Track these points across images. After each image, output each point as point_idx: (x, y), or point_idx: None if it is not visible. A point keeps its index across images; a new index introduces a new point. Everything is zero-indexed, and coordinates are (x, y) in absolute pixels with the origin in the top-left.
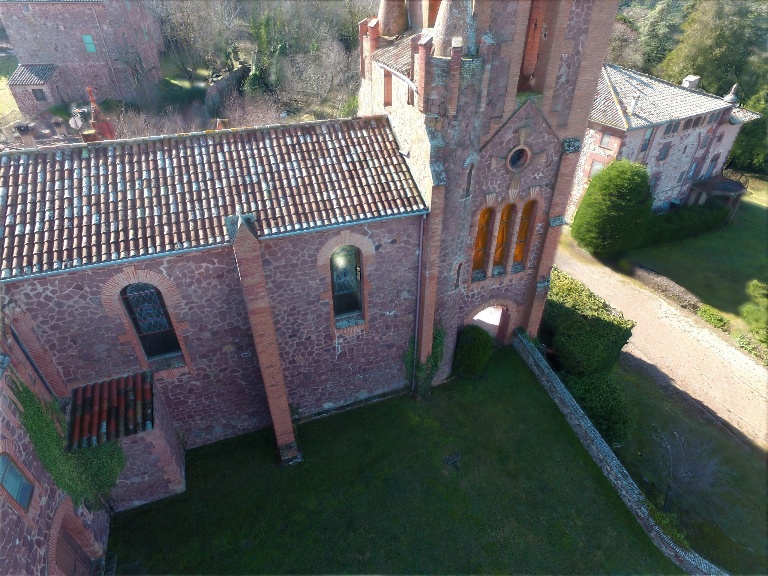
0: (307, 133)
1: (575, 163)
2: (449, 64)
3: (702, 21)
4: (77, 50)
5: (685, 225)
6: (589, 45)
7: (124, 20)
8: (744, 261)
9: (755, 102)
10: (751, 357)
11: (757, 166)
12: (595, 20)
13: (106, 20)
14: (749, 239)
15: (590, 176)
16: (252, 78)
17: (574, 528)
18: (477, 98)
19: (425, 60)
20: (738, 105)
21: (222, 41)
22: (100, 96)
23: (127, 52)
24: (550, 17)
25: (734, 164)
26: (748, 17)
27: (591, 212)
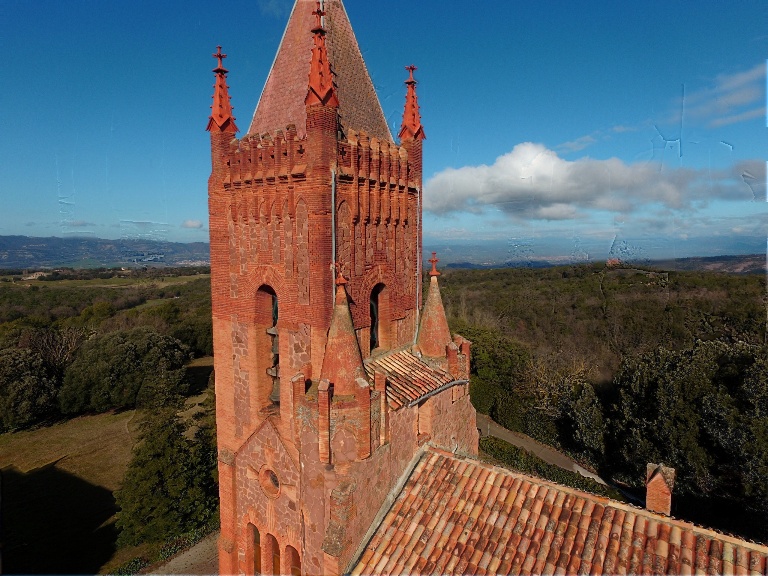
0: None
1: None
2: None
3: None
4: None
5: None
6: None
7: None
8: None
9: None
10: (180, 553)
11: None
12: None
13: None
14: None
15: None
16: None
17: None
18: None
19: None
20: None
21: None
22: None
23: None
24: None
25: None
26: None
27: None
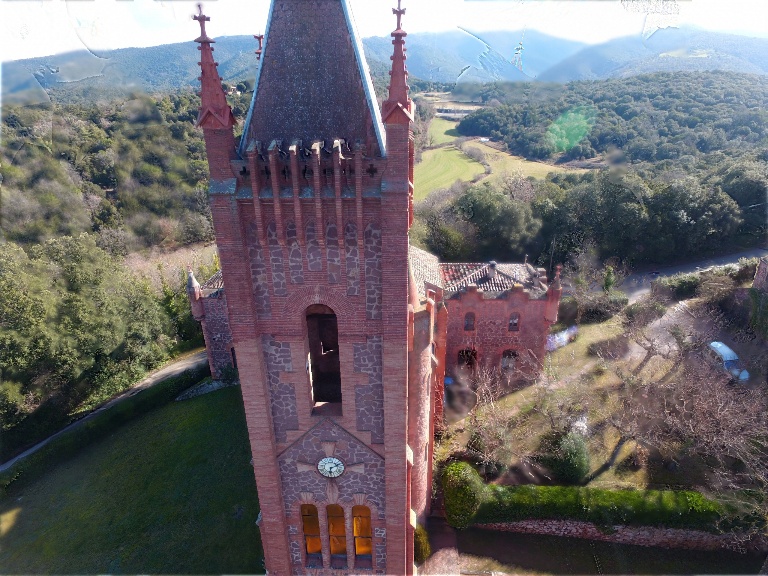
0: None
1: None
2: None
3: None
4: None
5: None
6: None
7: None
8: None
9: None
10: None
11: None
12: None
13: None
14: None
15: None
16: None
17: (151, 574)
18: None
19: None
20: None
21: None
22: None
23: None
24: None
25: None
26: None
27: None
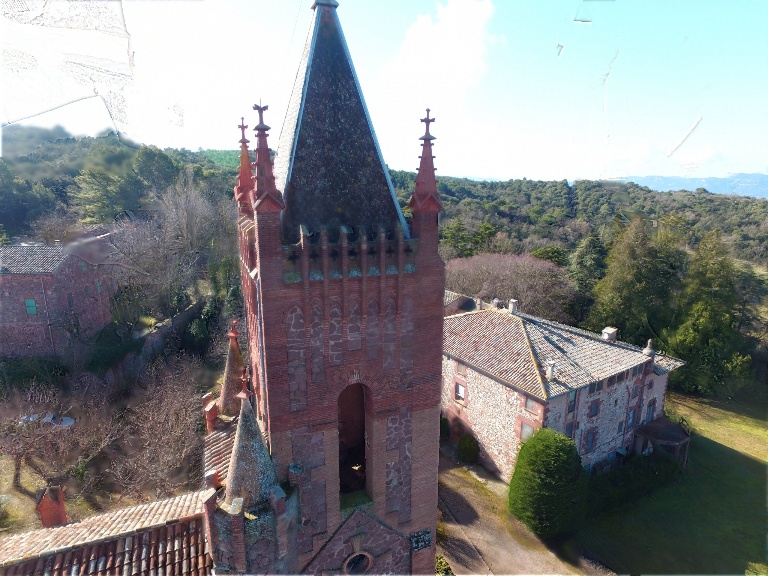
0: (103, 554)
1: (432, 552)
2: (231, 524)
3: (619, 260)
4: (18, 312)
5: (632, 487)
6: (417, 450)
7: (74, 282)
8: (705, 531)
9: (684, 331)
10: None
11: (703, 392)
12: (418, 429)
13: (52, 287)
14: (707, 495)
15: (522, 437)
16: (199, 321)
17: None
18: (275, 545)
19: (208, 515)
20: (660, 352)
21: (168, 296)
22: (32, 351)
23: (66, 314)
24: (368, 431)
25: (681, 389)
26: (658, 257)
27: (523, 487)
